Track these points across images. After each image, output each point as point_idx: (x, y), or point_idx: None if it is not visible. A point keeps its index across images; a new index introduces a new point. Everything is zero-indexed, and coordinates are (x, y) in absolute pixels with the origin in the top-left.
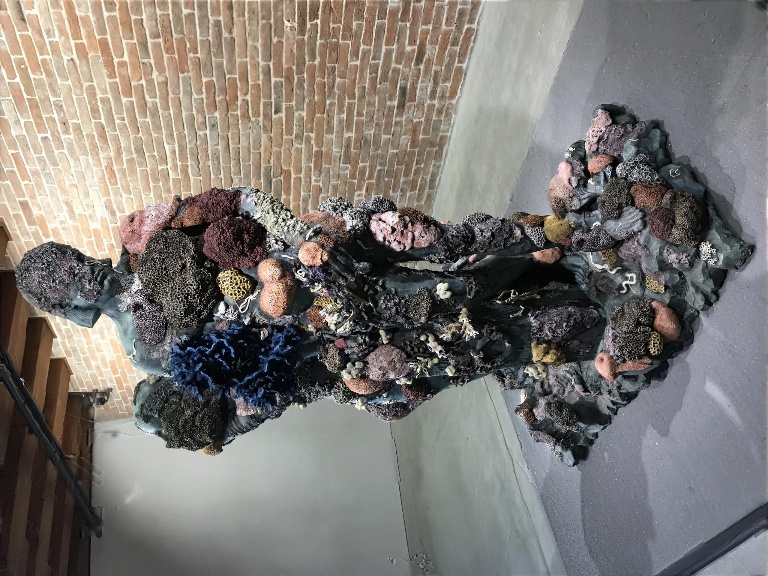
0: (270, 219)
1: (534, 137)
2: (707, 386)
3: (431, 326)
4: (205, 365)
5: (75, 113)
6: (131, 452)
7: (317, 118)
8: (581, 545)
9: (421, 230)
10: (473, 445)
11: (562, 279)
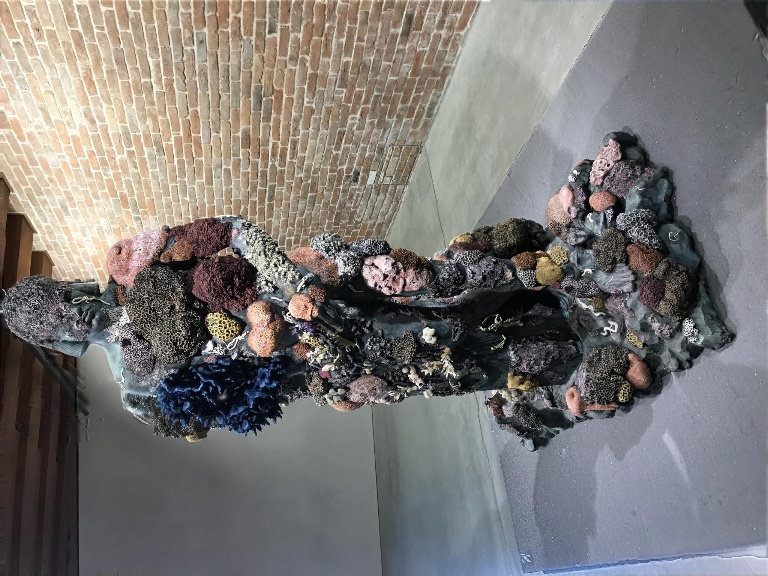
0: (261, 261)
1: (541, 122)
2: (666, 437)
3: None
4: (192, 404)
5: (49, 20)
6: None
7: (314, 40)
8: (530, 513)
9: (413, 276)
10: None
11: (547, 302)
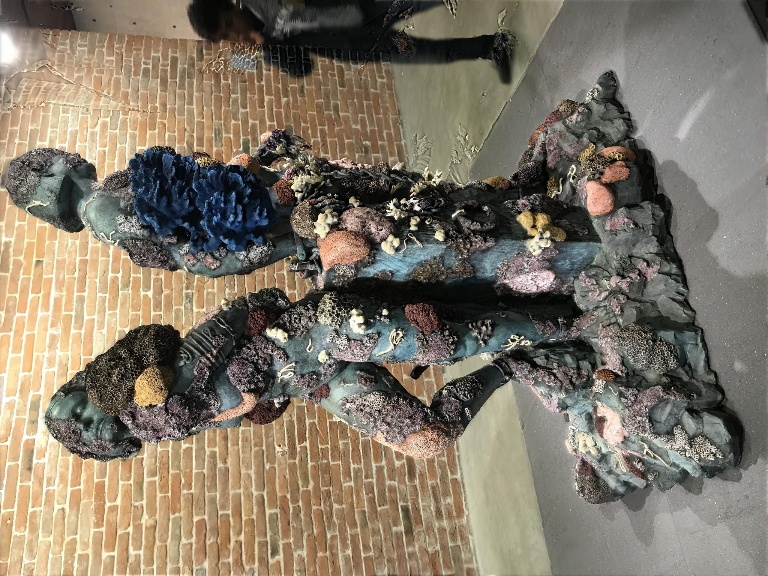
0: None
1: None
2: (680, 136)
3: None
4: None
5: None
6: None
7: (320, 560)
8: None
9: None
10: None
11: None
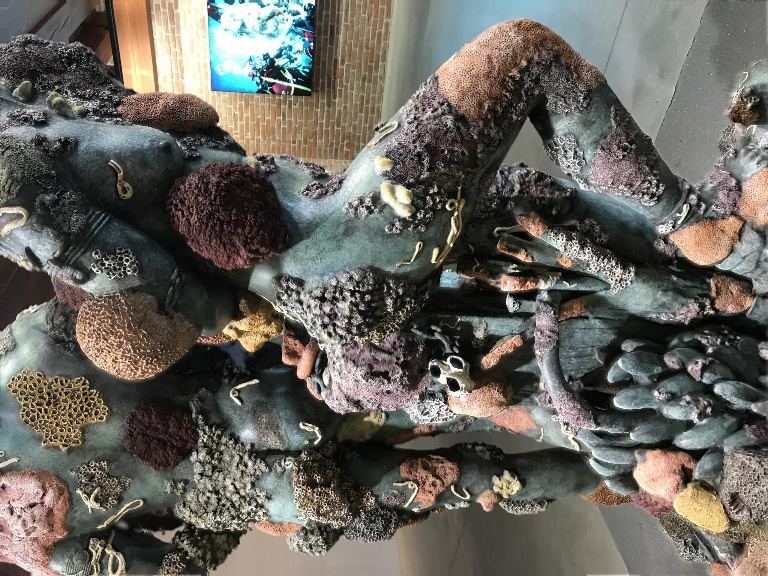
0: None
1: None
2: None
3: None
4: None
5: None
6: None
7: None
8: None
9: None
10: None
11: None
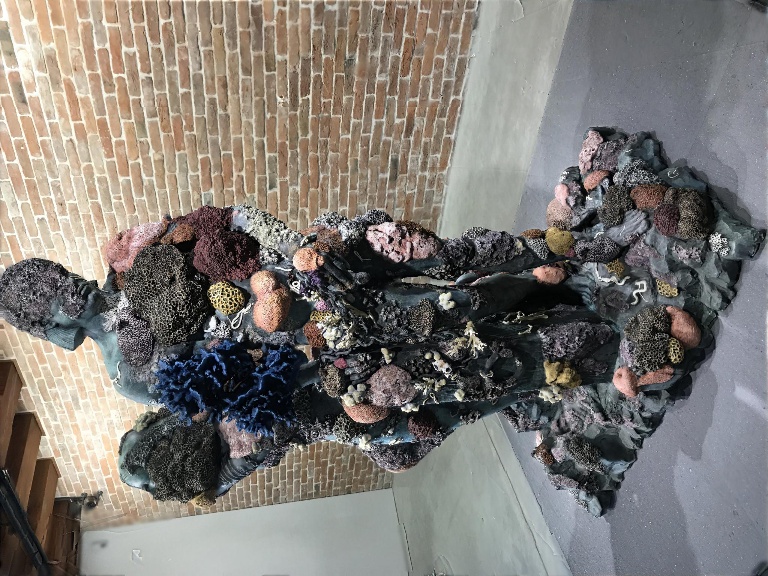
0: (263, 231)
1: (527, 181)
2: (737, 391)
3: (436, 344)
4: (194, 381)
5: (72, 193)
6: (119, 551)
7: (311, 192)
8: None
9: (419, 240)
10: (489, 526)
11: (569, 301)
